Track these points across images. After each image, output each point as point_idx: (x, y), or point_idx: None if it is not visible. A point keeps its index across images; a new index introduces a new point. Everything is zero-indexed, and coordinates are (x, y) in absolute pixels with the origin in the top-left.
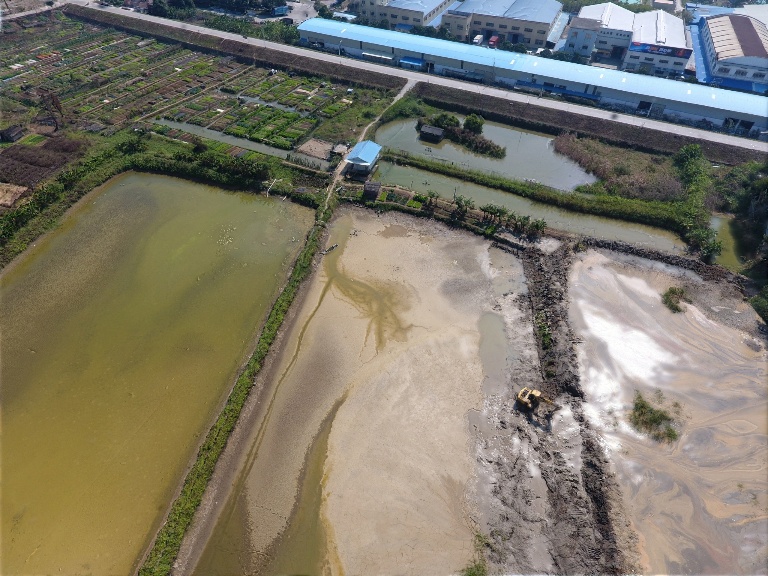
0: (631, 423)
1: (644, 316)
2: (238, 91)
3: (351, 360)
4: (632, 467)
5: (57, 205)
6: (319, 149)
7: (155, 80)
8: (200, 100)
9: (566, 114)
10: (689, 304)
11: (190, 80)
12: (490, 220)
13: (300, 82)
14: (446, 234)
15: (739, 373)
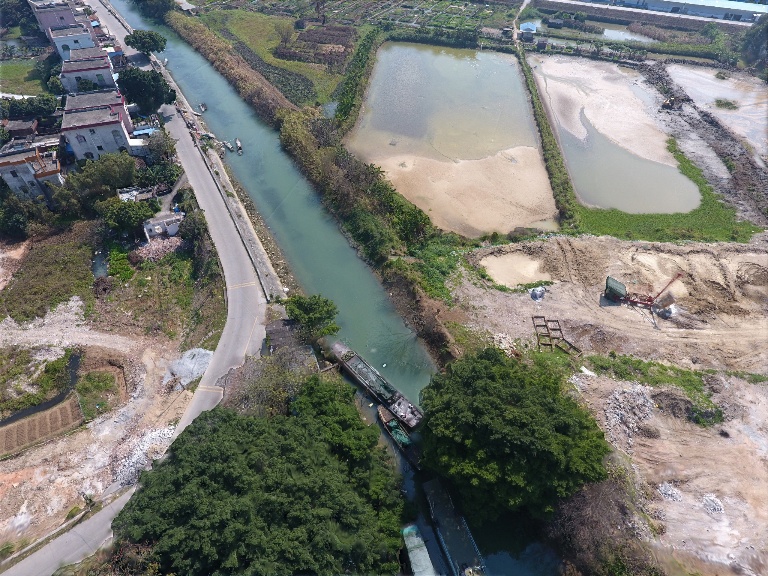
0: (717, 106)
1: (709, 81)
2: (414, 7)
3: (577, 98)
4: (722, 115)
5: (373, 50)
6: (493, 31)
7: (354, 2)
8: (395, 11)
9: (632, 13)
10: (729, 78)
11: (377, 2)
12: (614, 55)
13: (450, 3)
14: (591, 62)
15: (758, 93)
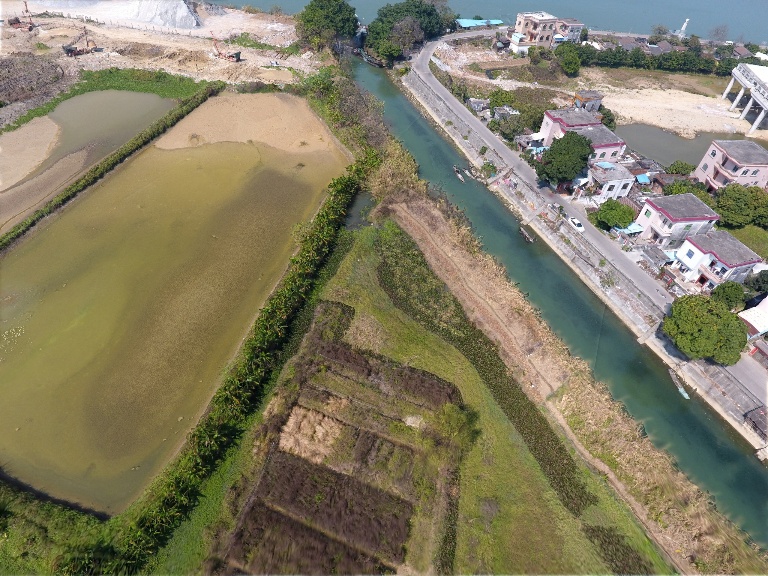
0: None
1: None
2: None
3: None
4: None
5: None
6: None
7: None
8: None
9: None
10: None
11: None
12: None
13: None
14: None
15: None
